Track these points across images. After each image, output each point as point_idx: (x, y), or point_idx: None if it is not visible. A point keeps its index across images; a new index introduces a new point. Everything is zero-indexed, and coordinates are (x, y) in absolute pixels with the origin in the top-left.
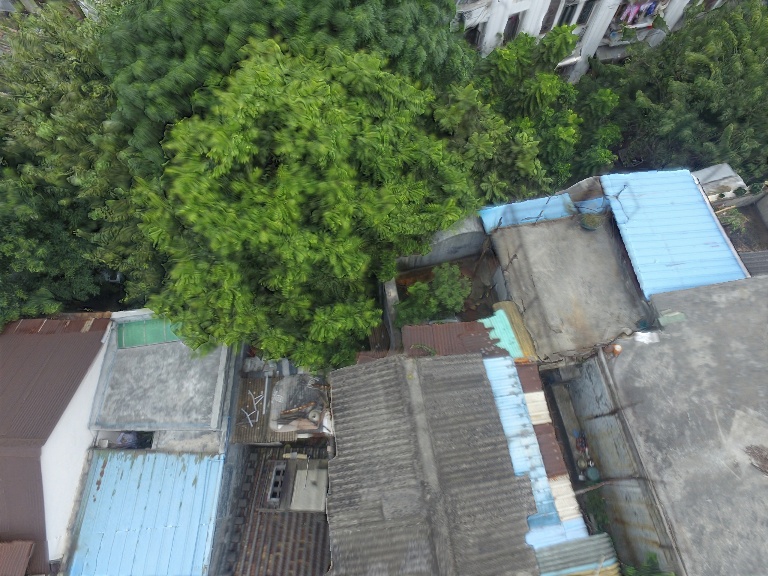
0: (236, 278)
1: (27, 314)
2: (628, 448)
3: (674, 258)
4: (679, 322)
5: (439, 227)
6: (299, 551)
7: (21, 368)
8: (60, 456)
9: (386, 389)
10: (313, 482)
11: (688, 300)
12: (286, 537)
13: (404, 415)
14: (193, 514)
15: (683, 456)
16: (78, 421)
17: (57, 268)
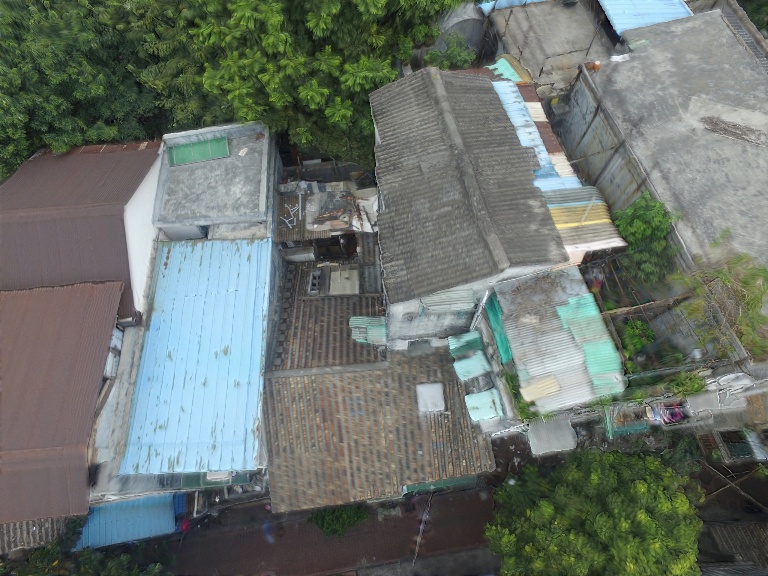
0: (287, 28)
1: (89, 139)
2: (609, 130)
3: (639, 11)
4: (645, 46)
5: (446, 5)
6: (340, 320)
7: (92, 171)
8: (135, 230)
9: (416, 93)
10: (346, 278)
11: (651, 32)
12: (328, 313)
13: (432, 106)
14: (250, 281)
15: (652, 128)
16: (145, 211)
17: (109, 110)
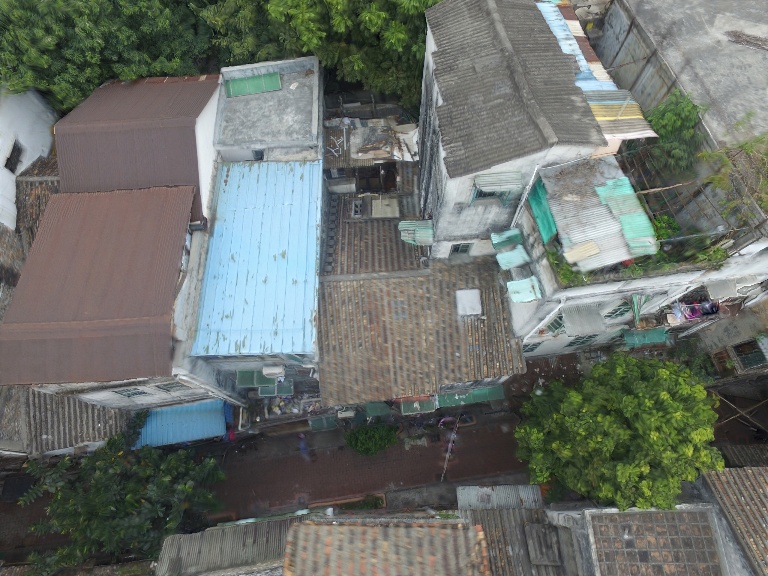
0: None
1: (153, 71)
2: (642, 43)
3: None
4: None
5: None
6: (383, 238)
7: (160, 95)
8: (201, 146)
9: (469, 7)
10: (387, 205)
11: None
12: (371, 233)
13: (484, 18)
14: (303, 196)
15: (681, 40)
16: (208, 132)
17: (169, 47)
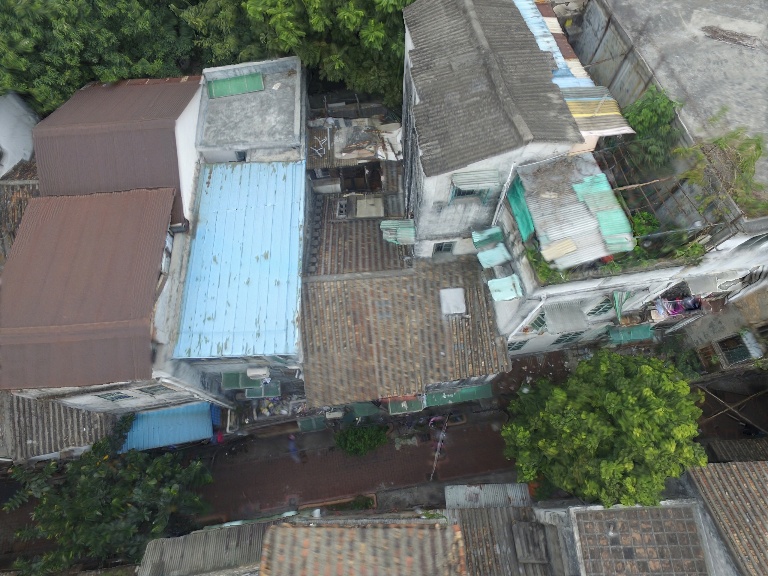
0: None
1: (135, 73)
2: (620, 40)
3: None
4: None
5: None
6: (368, 238)
7: (140, 97)
8: (182, 147)
9: (446, 5)
10: (372, 204)
11: None
12: (356, 233)
13: (460, 16)
14: (286, 197)
15: (658, 36)
16: (189, 134)
17: (151, 49)
